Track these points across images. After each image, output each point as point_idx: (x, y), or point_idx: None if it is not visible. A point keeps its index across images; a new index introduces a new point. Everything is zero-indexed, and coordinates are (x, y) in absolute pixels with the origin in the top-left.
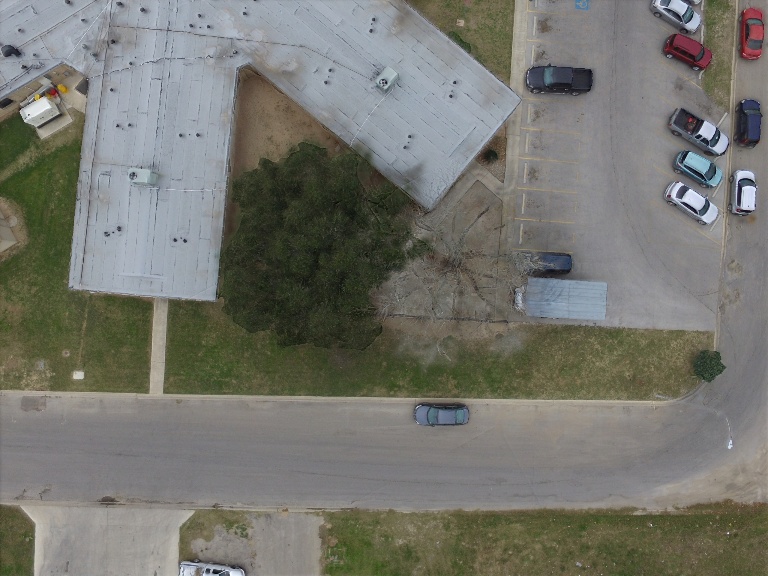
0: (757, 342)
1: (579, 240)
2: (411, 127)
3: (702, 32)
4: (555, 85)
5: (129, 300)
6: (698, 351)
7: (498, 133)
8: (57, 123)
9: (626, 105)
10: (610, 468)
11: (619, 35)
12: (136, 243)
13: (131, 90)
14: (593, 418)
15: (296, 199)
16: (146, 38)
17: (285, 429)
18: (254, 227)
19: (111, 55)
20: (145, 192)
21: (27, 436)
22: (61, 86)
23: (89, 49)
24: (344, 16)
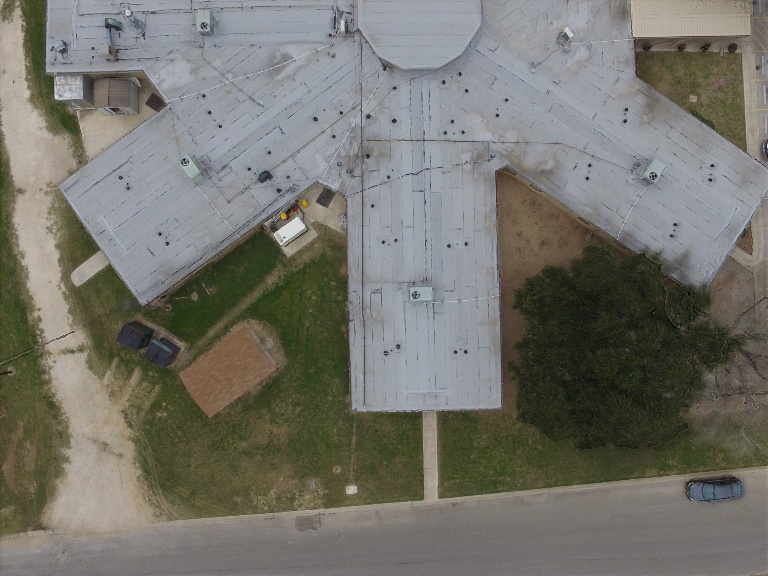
0: None
1: None
2: (675, 215)
3: None
4: None
5: (397, 411)
6: None
7: None
8: (302, 239)
9: None
10: None
11: None
12: (417, 359)
13: (392, 204)
14: None
15: (605, 310)
16: (401, 149)
17: (561, 519)
18: (561, 340)
19: (367, 170)
20: (421, 307)
21: (305, 556)
22: (306, 202)
23: (343, 166)
24: (597, 108)
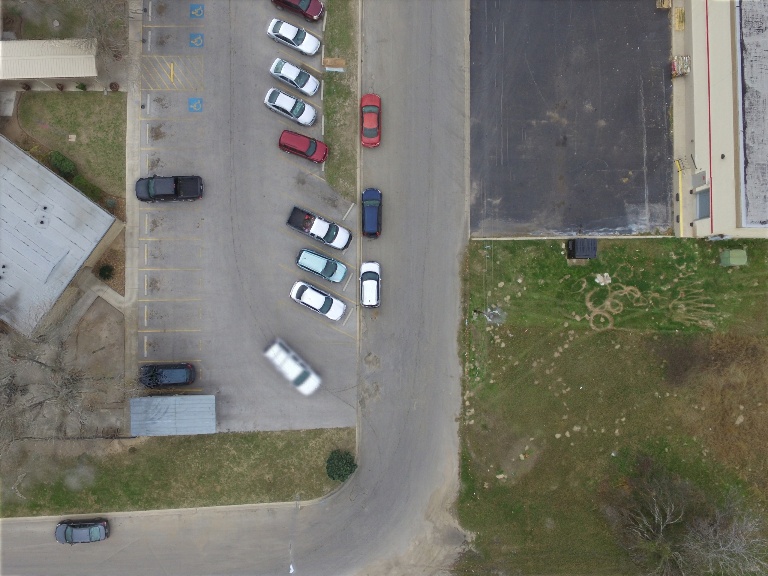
0: (401, 434)
1: (206, 347)
2: (5, 257)
3: (322, 123)
4: (160, 196)
5: None
6: (335, 449)
7: (116, 247)
8: None
9: (247, 205)
10: (258, 571)
11: (236, 134)
12: None
13: None
14: (237, 523)
15: None
16: None
17: None
18: None
19: None
20: None
21: None
22: None
23: None
24: None
